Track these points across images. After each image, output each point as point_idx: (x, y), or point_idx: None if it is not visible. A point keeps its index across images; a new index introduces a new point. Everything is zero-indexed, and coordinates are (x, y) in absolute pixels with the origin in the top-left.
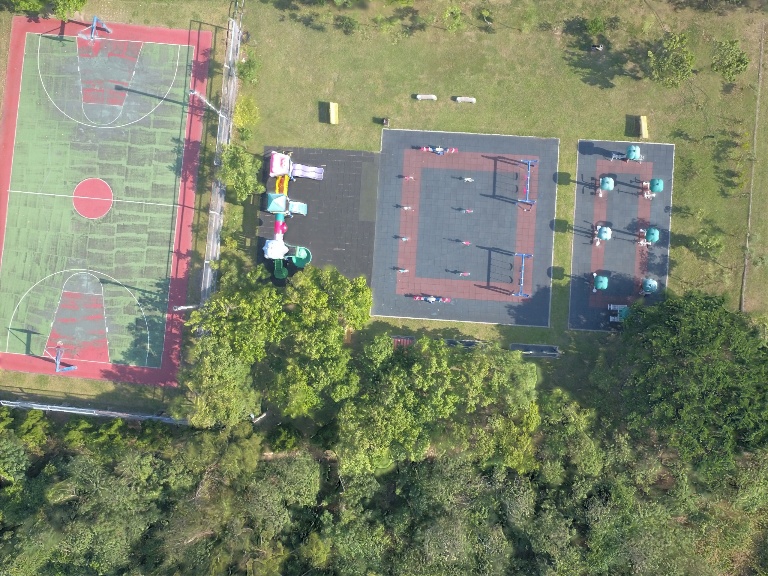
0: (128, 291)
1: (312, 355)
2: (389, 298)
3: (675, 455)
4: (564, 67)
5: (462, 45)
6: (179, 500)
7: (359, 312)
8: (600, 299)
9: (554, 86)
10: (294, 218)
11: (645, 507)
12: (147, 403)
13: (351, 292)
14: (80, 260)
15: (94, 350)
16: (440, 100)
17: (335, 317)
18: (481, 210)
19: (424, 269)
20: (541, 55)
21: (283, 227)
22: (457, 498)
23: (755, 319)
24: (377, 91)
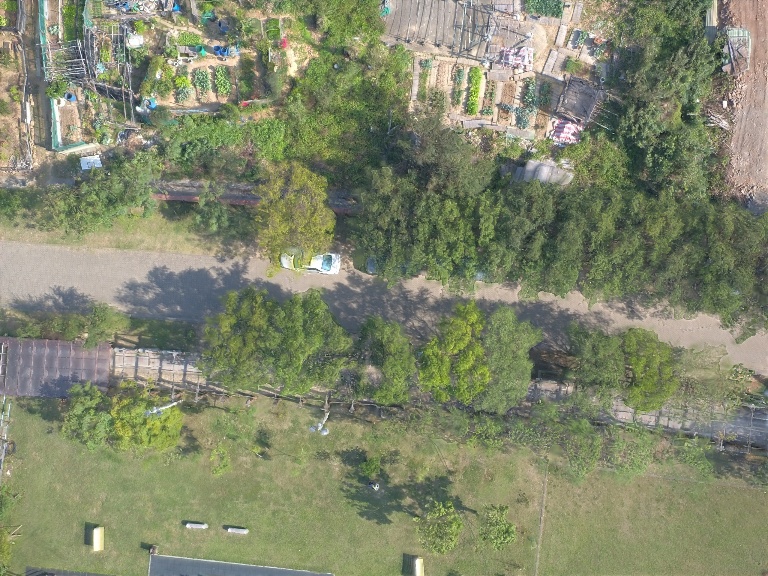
0: None
1: None
2: None
3: None
4: (341, 499)
5: (236, 471)
6: None
7: None
8: None
9: (330, 519)
10: None
11: None
12: None
13: None
14: None
15: None
16: (211, 528)
17: None
18: None
19: None
20: (318, 485)
21: None
22: None
23: None
24: (147, 514)
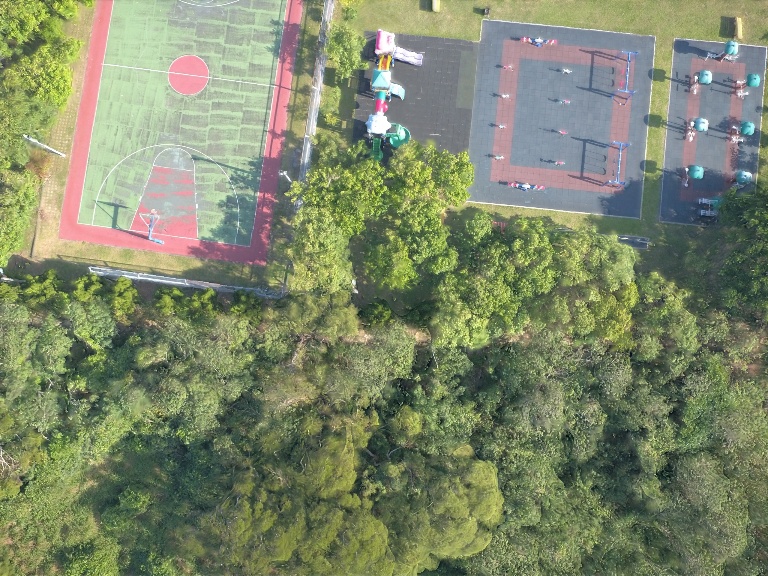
0: (220, 168)
1: (414, 227)
2: (483, 185)
3: None
4: None
5: None
6: (275, 366)
7: (460, 189)
8: (691, 194)
9: None
10: (391, 102)
11: (743, 385)
12: (234, 281)
13: (456, 165)
14: (173, 135)
15: (183, 226)
16: None
17: (435, 194)
18: (577, 102)
19: (519, 158)
20: None
21: (385, 105)
22: (557, 371)
23: None
24: None
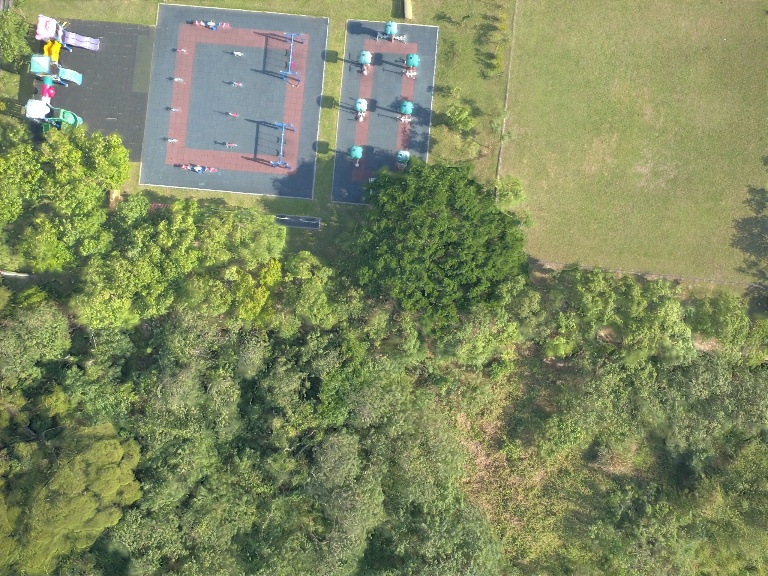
0: None
1: None
2: (158, 167)
3: (399, 306)
4: None
5: None
6: None
7: (116, 172)
8: (362, 173)
9: None
10: (69, 87)
11: (376, 361)
12: None
13: (103, 148)
14: None
15: None
16: None
17: (93, 177)
18: (251, 84)
19: (193, 140)
20: None
21: (49, 90)
22: (194, 349)
23: (490, 184)
24: None
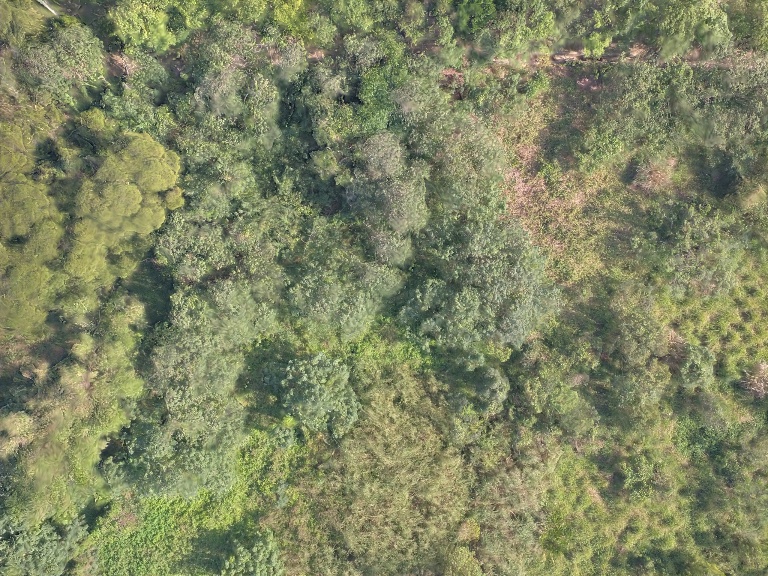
0: None
1: None
2: None
3: None
4: None
5: None
6: None
7: None
8: None
9: None
10: None
11: (413, 58)
12: None
13: None
14: None
15: None
16: None
17: None
18: None
19: None
20: None
21: None
22: (230, 55)
23: None
24: None
